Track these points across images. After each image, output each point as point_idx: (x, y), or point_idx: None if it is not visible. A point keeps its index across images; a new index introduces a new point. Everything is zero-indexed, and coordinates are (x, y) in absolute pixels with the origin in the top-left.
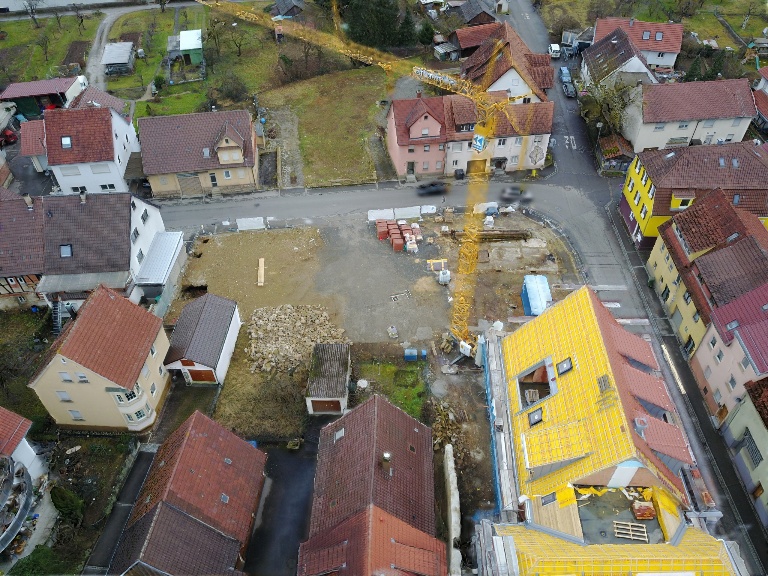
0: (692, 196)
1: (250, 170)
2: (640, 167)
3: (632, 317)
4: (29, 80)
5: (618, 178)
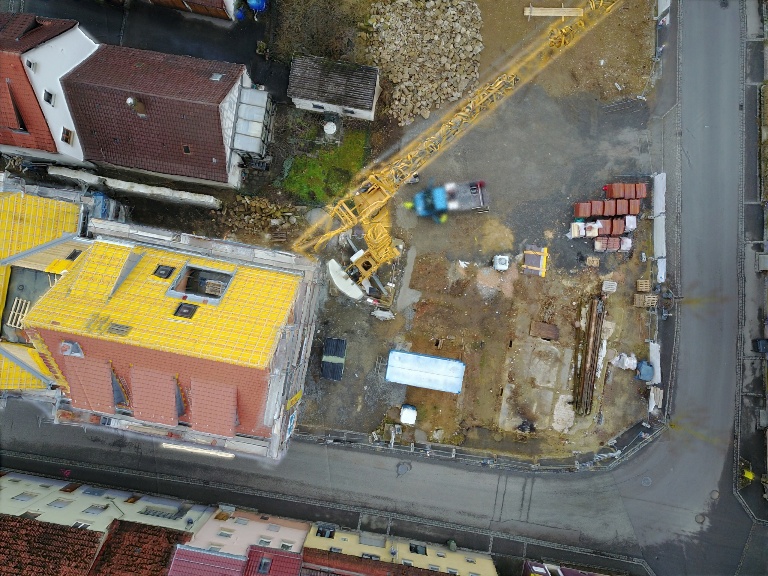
0: None
1: None
2: None
3: (397, 491)
4: None
5: None
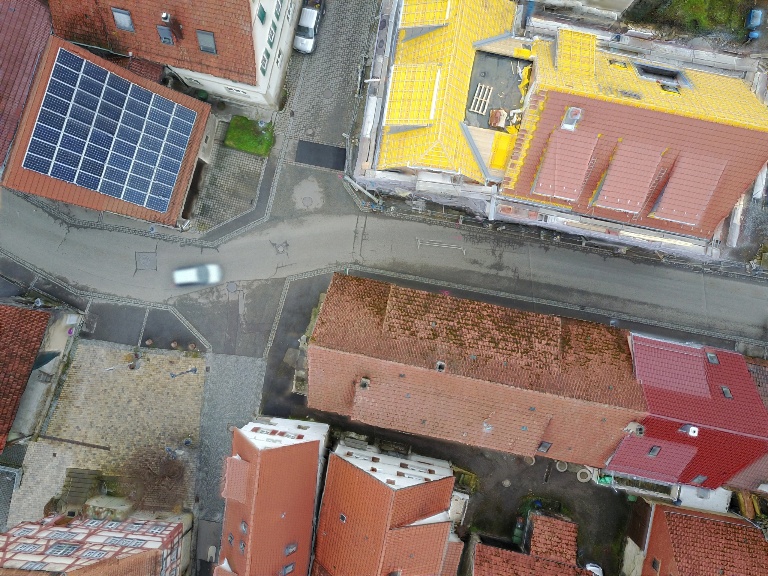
0: None
1: None
2: None
3: None
4: None
5: None
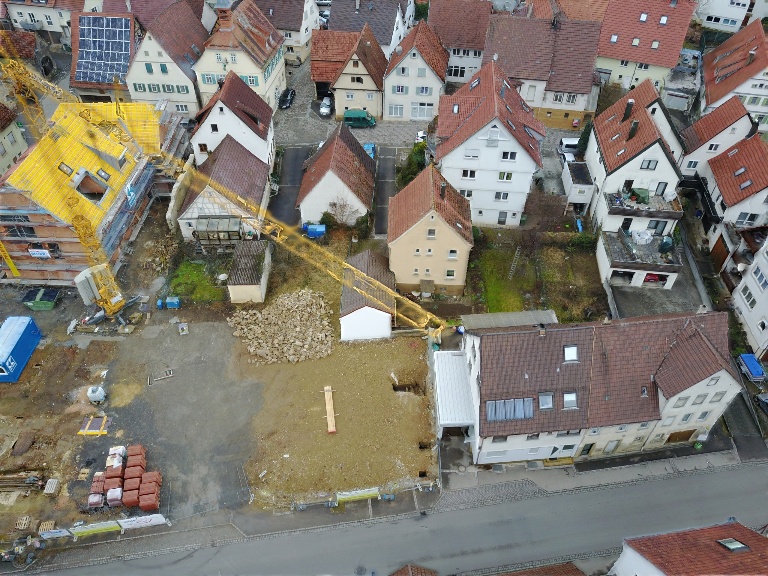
0: None
1: None
2: None
3: None
4: None
5: None
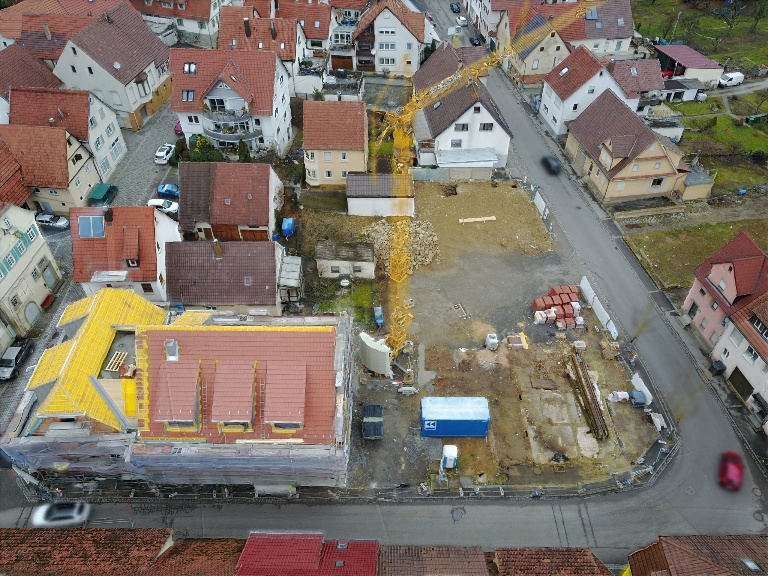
0: None
1: (607, 182)
2: None
3: (458, 537)
4: (722, 57)
5: None
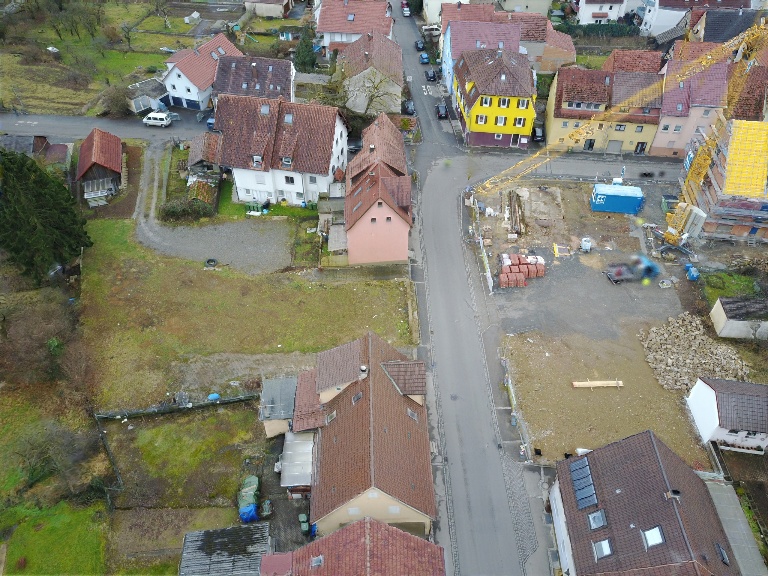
0: (535, 89)
1: None
2: (490, 100)
3: (606, 167)
4: None
5: (424, 137)
